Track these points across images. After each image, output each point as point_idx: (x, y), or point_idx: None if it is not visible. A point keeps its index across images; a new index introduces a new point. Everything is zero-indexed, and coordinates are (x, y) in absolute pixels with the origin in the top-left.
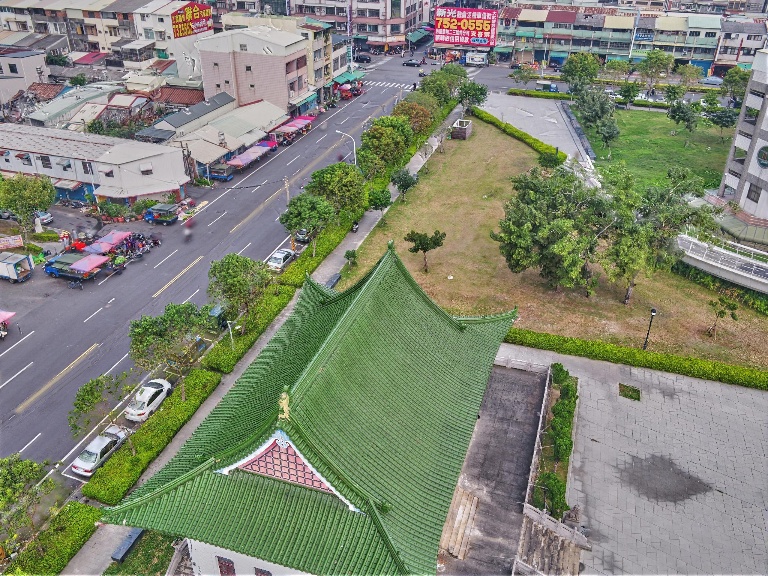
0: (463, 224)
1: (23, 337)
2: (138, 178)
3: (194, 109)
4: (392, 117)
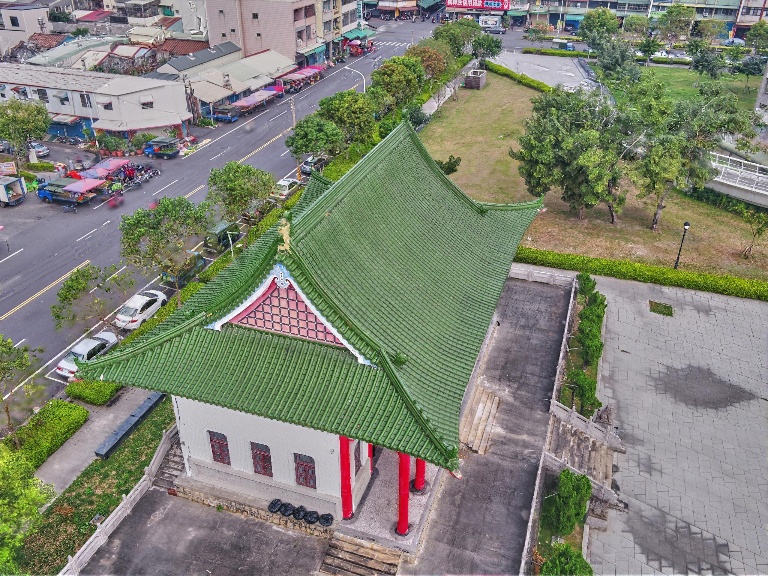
0: (478, 160)
1: (11, 254)
2: (138, 111)
3: (198, 55)
4: (404, 56)
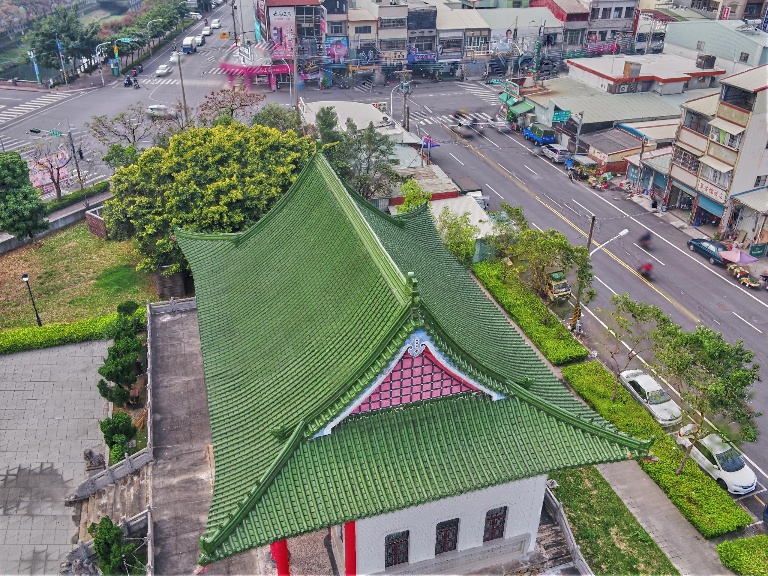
0: None
1: None
2: None
3: None
4: None
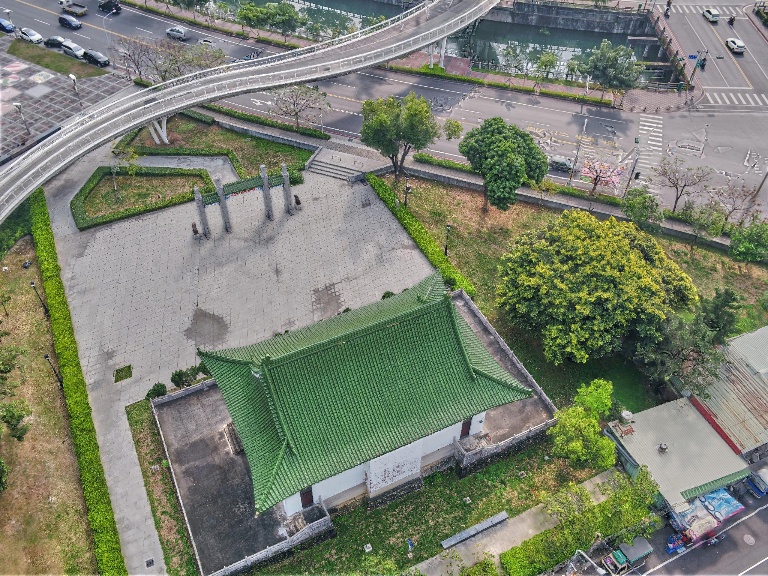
0: None
1: None
2: None
3: None
4: None
